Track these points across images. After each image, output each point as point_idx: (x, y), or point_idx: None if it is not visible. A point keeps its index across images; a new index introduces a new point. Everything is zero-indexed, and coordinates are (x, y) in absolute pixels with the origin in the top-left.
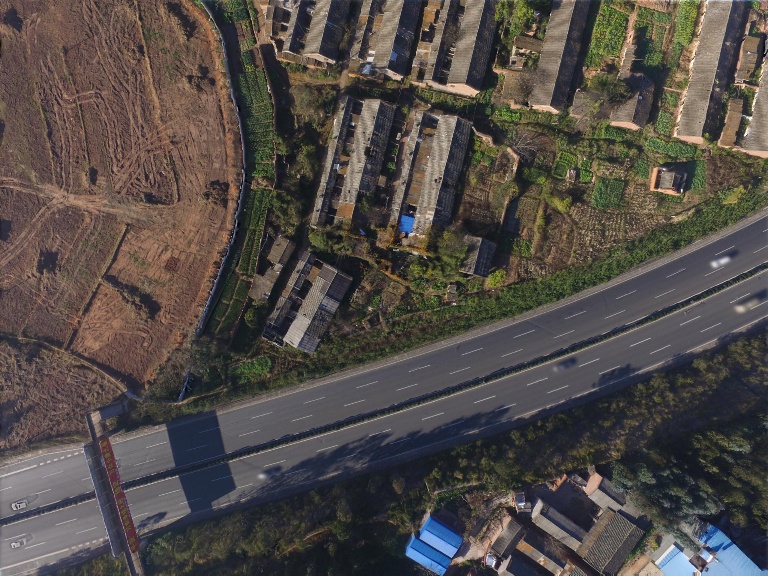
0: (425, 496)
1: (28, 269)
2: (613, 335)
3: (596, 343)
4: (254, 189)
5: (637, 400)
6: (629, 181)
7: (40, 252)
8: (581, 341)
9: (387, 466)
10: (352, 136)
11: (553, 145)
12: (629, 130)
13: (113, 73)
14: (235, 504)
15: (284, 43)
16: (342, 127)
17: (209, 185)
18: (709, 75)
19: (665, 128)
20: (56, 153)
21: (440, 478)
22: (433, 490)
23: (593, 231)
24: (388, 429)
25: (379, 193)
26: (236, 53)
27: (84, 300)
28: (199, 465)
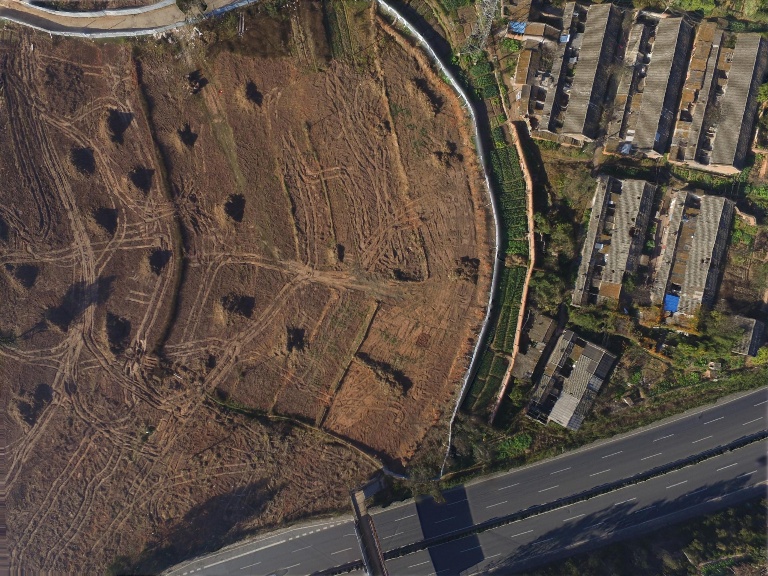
0: (690, 568)
1: (276, 346)
2: None
3: None
4: (507, 266)
5: None
6: None
7: (287, 329)
8: None
9: (635, 534)
10: (611, 215)
11: None
12: None
13: (359, 149)
14: (483, 574)
15: (541, 122)
16: (603, 207)
17: (460, 262)
18: None
19: None
20: (300, 229)
21: (702, 550)
22: (698, 562)
23: None
24: (633, 498)
25: (638, 271)
26: (486, 130)
27: (334, 377)
28: (450, 537)
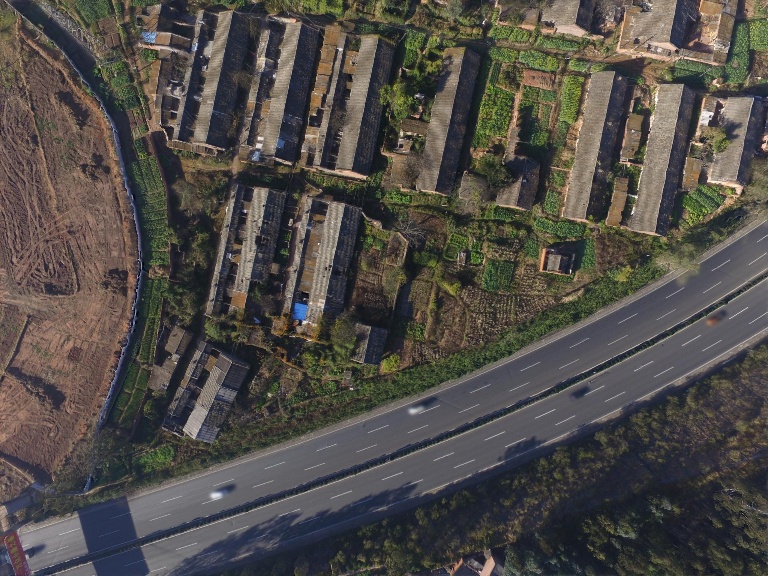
0: None
1: None
2: (517, 408)
3: (501, 416)
4: (152, 277)
5: (538, 476)
6: (519, 262)
7: None
8: (486, 415)
9: (297, 546)
10: (244, 223)
11: (444, 227)
12: (518, 210)
13: (8, 164)
14: None
15: (174, 131)
16: (233, 215)
17: (107, 274)
18: (592, 156)
19: (553, 208)
20: None
21: (343, 562)
22: (336, 574)
23: (484, 314)
24: (297, 509)
25: (273, 280)
26: (129, 141)
27: None
28: (111, 551)
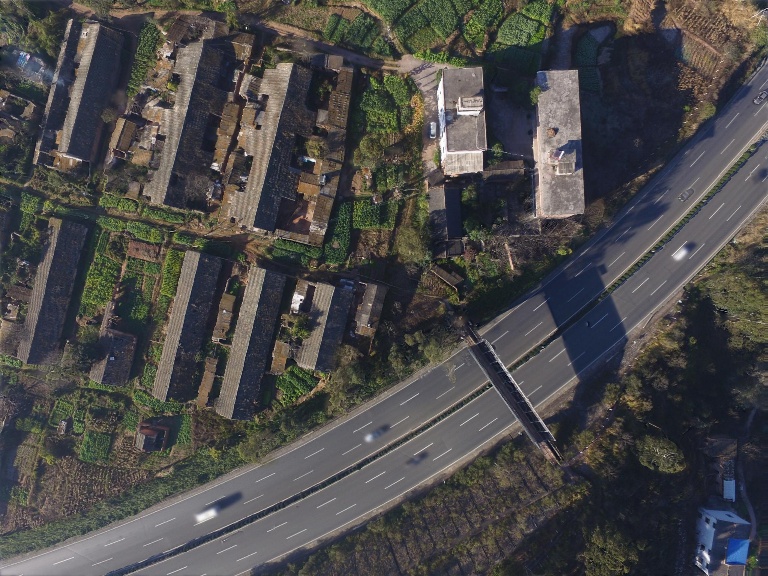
0: None
1: None
2: (146, 565)
3: (132, 572)
4: None
5: None
6: (118, 434)
7: None
8: (118, 569)
9: None
10: None
11: None
12: None
13: None
14: None
15: None
16: None
17: None
18: (176, 338)
19: (150, 382)
20: None
21: None
22: None
23: (79, 486)
24: None
25: None
26: None
27: None
28: None
